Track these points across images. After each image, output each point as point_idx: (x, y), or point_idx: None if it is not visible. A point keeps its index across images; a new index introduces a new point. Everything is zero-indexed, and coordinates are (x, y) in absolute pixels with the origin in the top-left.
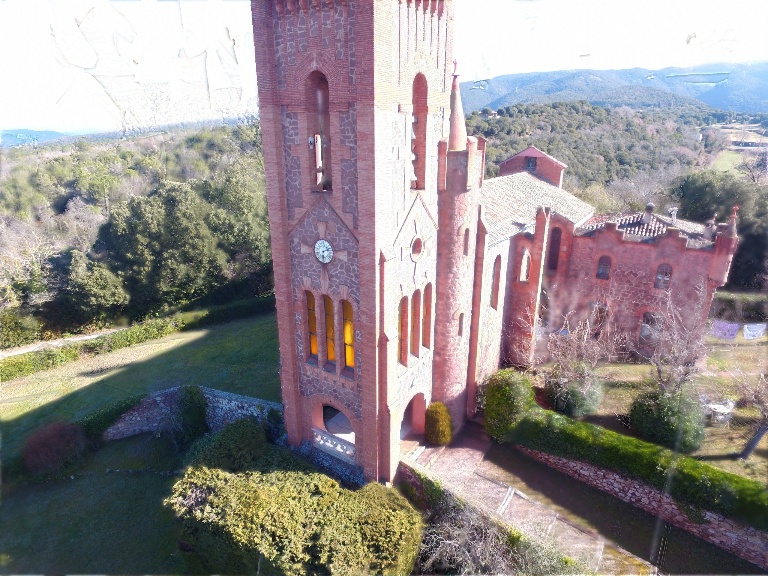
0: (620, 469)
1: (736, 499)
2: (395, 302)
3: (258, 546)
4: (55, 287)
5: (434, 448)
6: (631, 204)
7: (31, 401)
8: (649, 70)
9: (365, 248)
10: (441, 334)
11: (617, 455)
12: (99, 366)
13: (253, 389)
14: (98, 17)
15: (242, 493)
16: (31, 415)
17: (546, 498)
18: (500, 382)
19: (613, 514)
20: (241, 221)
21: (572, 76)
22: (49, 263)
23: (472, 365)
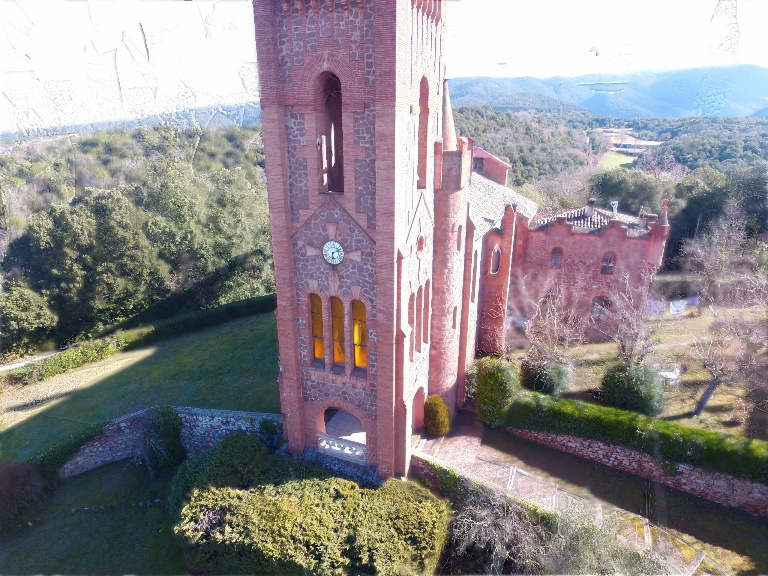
0: (603, 437)
1: (704, 449)
2: None
3: (294, 558)
4: None
5: (435, 439)
6: (560, 200)
7: None
8: (559, 79)
9: (383, 247)
10: (437, 328)
11: (601, 425)
12: (32, 397)
13: (230, 403)
14: None
15: (261, 508)
16: None
17: (544, 472)
18: (491, 369)
19: (602, 478)
20: (183, 229)
21: (494, 83)
22: None
23: (462, 356)
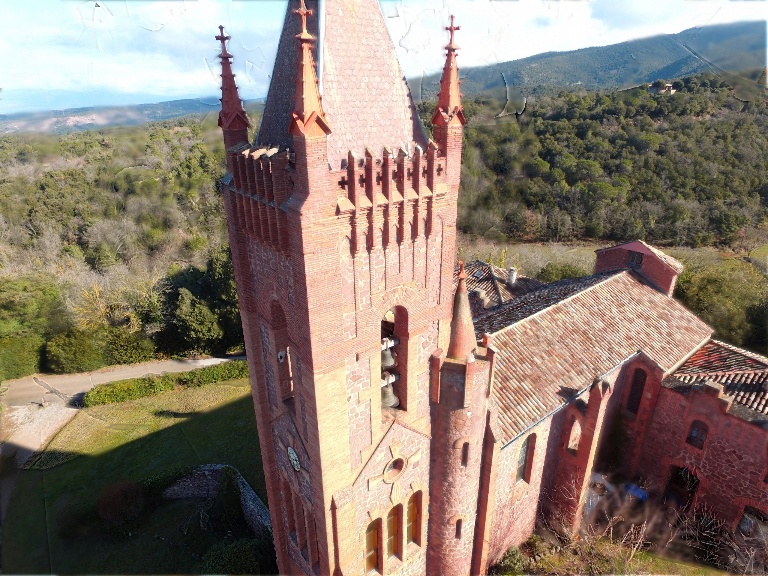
0: None
1: None
2: (360, 529)
3: None
4: (165, 319)
5: None
6: None
7: (128, 433)
8: None
9: (317, 491)
10: (435, 533)
11: None
12: (186, 403)
13: None
14: (233, 47)
15: None
16: (123, 450)
17: None
18: None
19: None
20: None
21: None
22: (163, 297)
23: (477, 560)
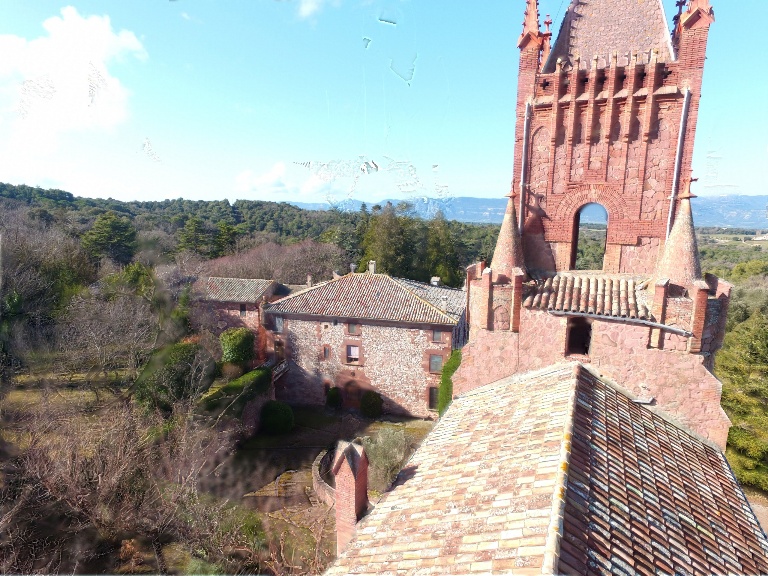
0: None
1: None
2: None
3: None
4: None
5: None
6: None
7: None
8: None
9: None
10: None
11: None
12: None
13: None
14: None
15: None
16: None
17: None
18: None
19: None
20: None
21: None
22: None
23: None
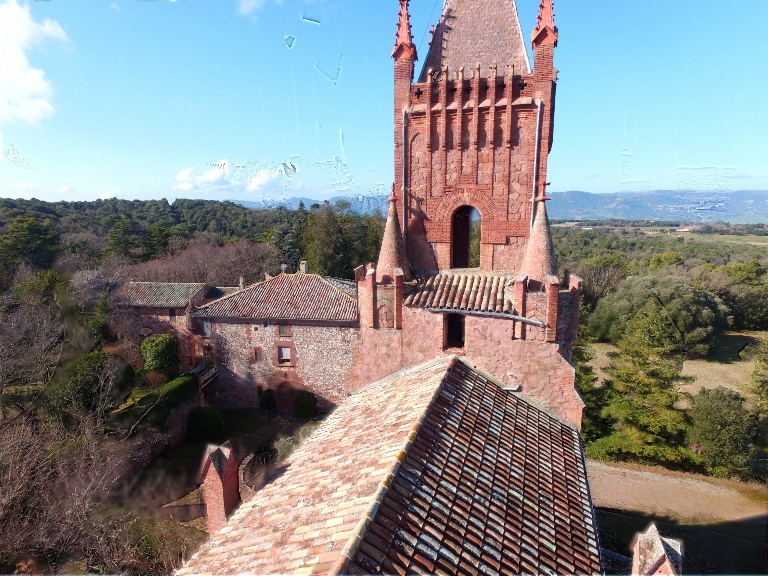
0: None
1: None
2: None
3: None
4: None
5: None
6: None
7: None
8: None
9: None
10: None
11: None
12: None
13: None
14: None
15: None
16: None
17: None
18: None
19: None
20: None
21: None
22: None
23: None
